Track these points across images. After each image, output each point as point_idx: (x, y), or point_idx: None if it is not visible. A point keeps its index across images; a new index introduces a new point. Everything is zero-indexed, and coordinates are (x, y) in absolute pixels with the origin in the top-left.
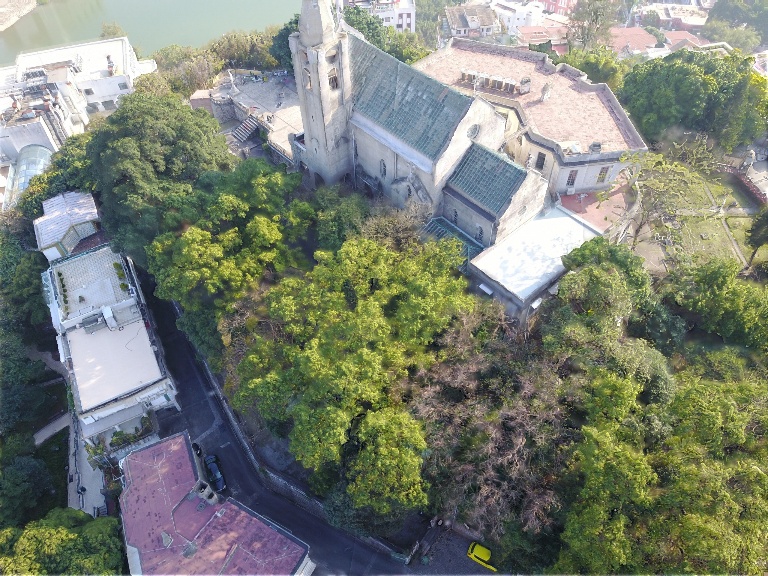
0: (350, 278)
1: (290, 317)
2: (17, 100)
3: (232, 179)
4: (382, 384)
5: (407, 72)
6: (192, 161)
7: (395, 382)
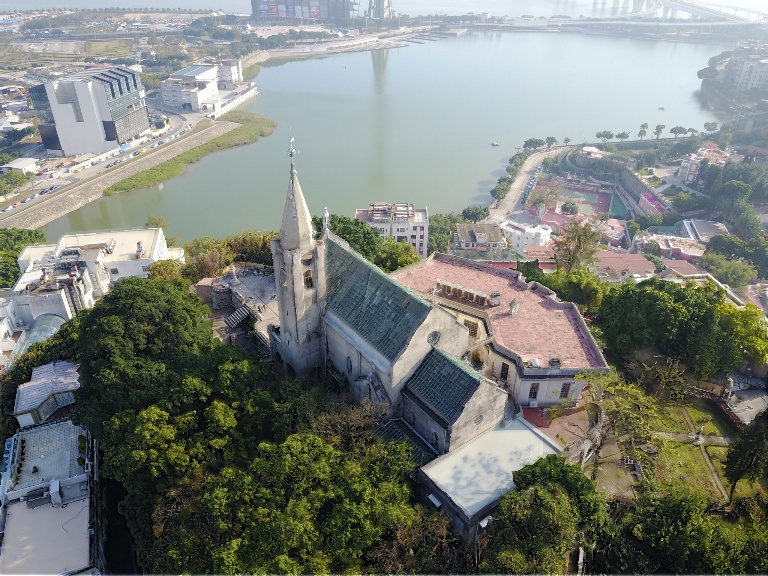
0: (293, 474)
1: (220, 511)
2: (46, 273)
3: (201, 363)
4: None
5: (377, 279)
6: (173, 342)
7: None
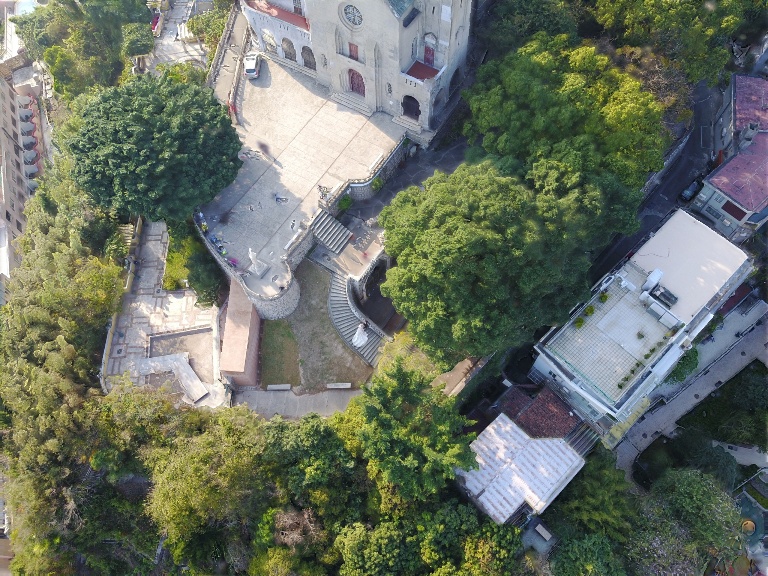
0: None
1: None
2: None
3: None
4: None
5: None
6: None
7: None
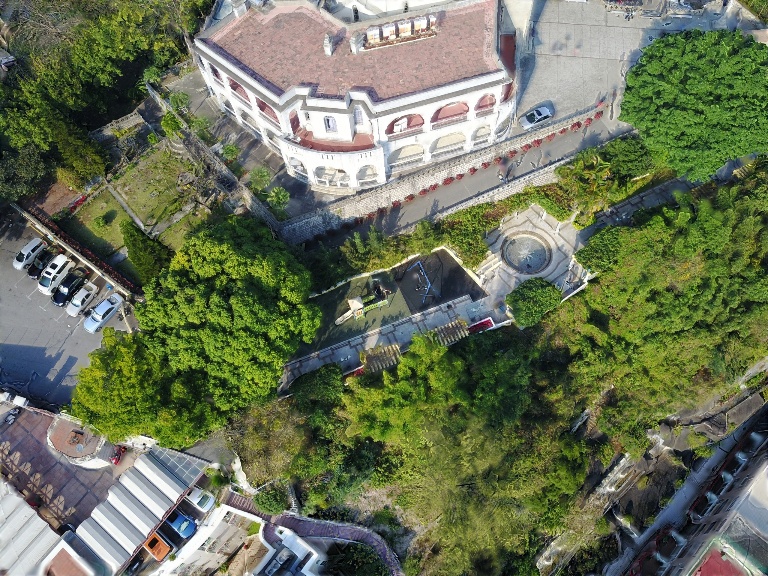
0: None
1: None
2: None
3: None
4: None
5: None
6: None
7: None
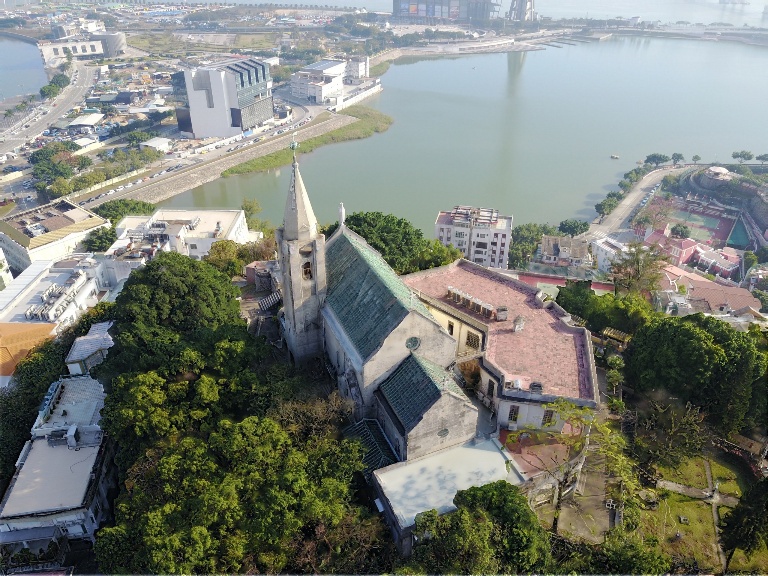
0: None
1: (169, 476)
2: None
3: (204, 338)
4: (207, 571)
5: (373, 278)
6: (193, 316)
7: (224, 574)
